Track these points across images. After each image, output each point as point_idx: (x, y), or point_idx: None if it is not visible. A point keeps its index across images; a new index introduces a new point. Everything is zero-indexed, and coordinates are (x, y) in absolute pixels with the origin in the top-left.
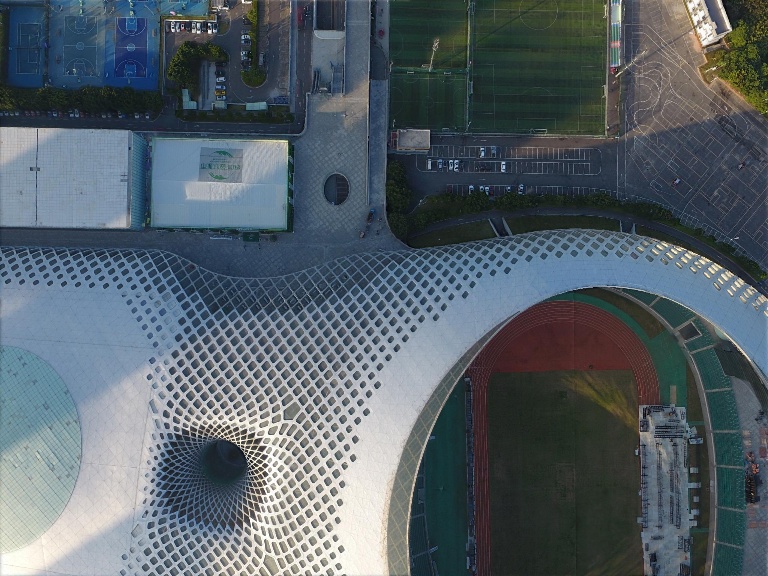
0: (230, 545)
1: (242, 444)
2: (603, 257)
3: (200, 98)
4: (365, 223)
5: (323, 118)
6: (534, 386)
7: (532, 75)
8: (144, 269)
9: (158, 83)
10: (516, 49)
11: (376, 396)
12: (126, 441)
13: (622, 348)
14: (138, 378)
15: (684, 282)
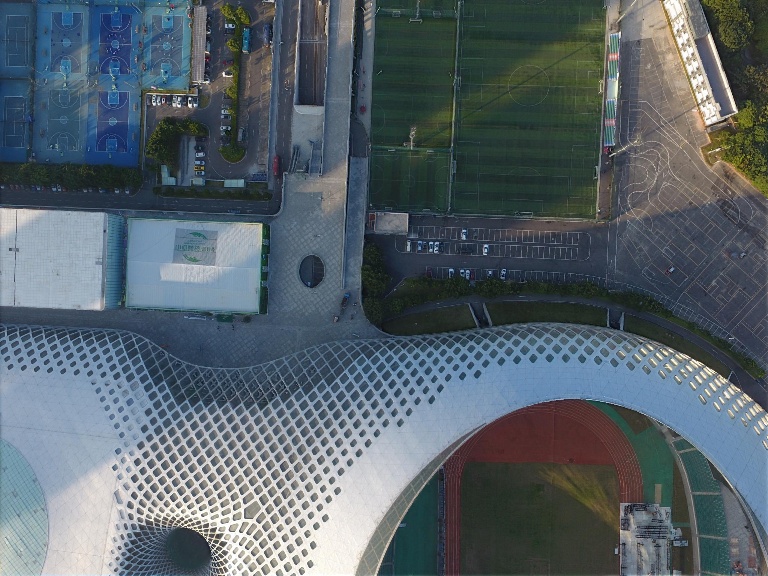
0: None
1: (205, 536)
2: (580, 364)
3: (179, 173)
4: (339, 307)
5: (300, 198)
6: (510, 477)
7: (519, 154)
8: (115, 355)
9: (138, 158)
10: (503, 126)
11: (335, 502)
12: (91, 530)
13: (605, 442)
14: (104, 468)
15: (666, 395)
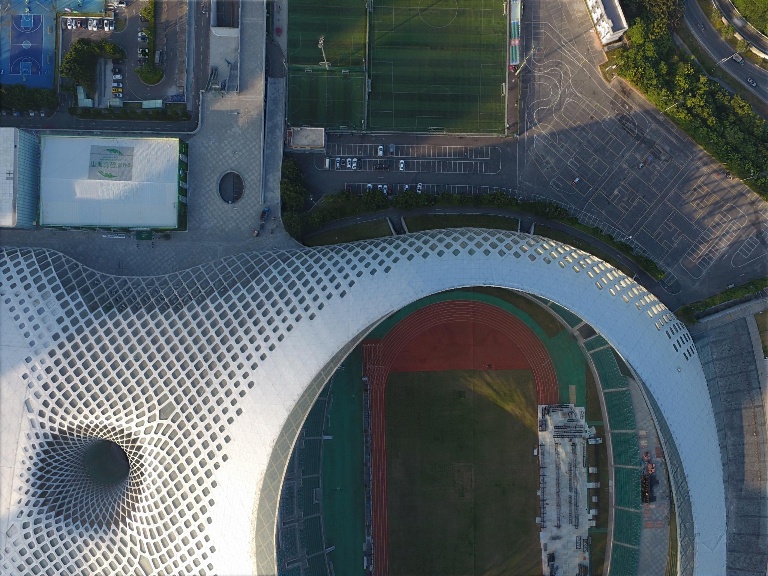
0: (106, 545)
1: (121, 444)
2: (484, 256)
3: (96, 96)
4: (259, 222)
5: (217, 116)
6: (432, 386)
7: (431, 73)
8: (26, 268)
9: (54, 80)
10: (415, 47)
11: (249, 396)
12: (1, 441)
13: (521, 347)
14: (13, 377)
15: (564, 281)
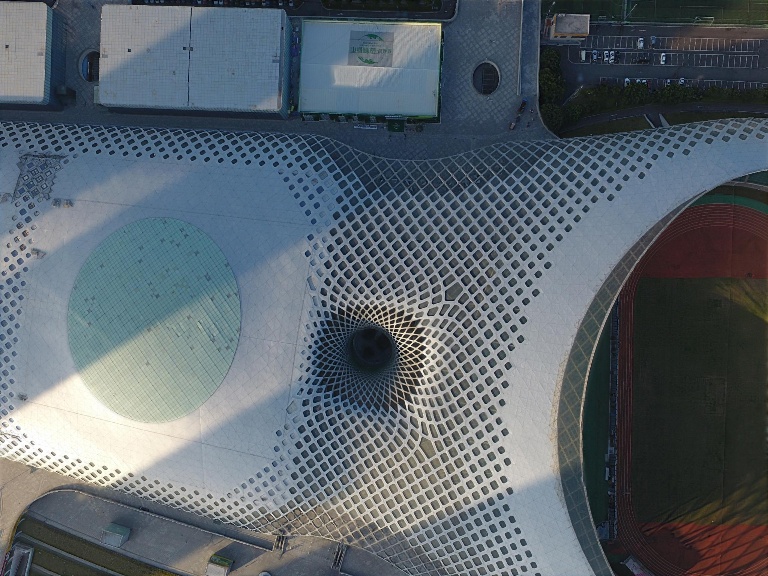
0: (385, 426)
1: (396, 328)
2: None
3: None
4: (515, 114)
5: (475, 3)
6: (686, 293)
7: None
8: (298, 149)
9: None
10: None
11: (546, 276)
12: (284, 317)
13: None
14: (296, 254)
15: None
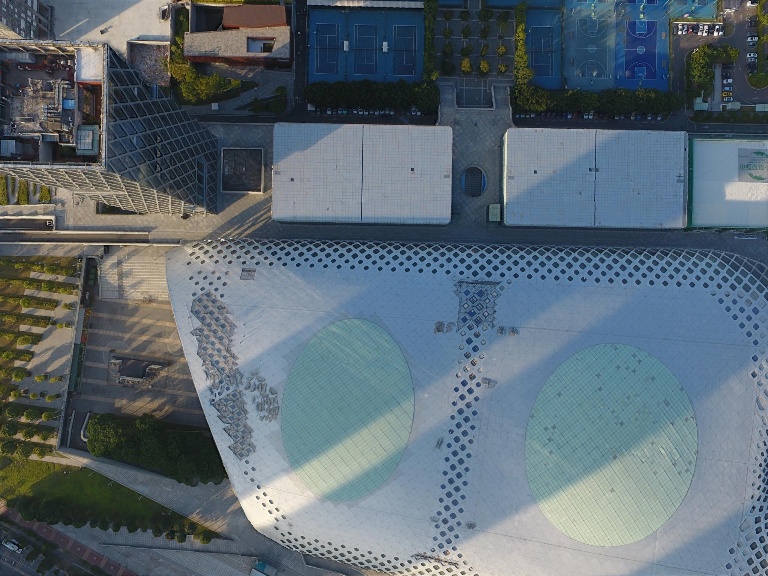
0: None
1: None
2: None
3: (709, 99)
4: None
5: None
6: None
7: None
8: (720, 268)
9: (668, 85)
10: None
11: None
12: (736, 437)
13: None
14: (743, 375)
15: None
